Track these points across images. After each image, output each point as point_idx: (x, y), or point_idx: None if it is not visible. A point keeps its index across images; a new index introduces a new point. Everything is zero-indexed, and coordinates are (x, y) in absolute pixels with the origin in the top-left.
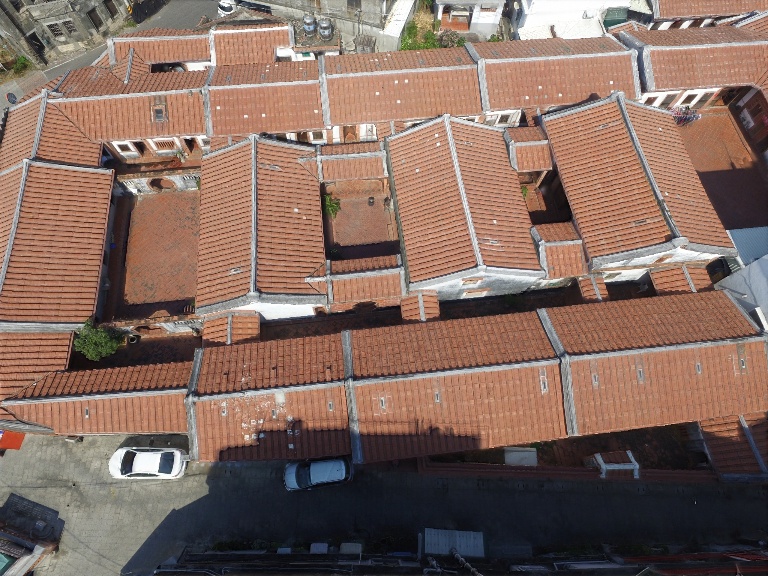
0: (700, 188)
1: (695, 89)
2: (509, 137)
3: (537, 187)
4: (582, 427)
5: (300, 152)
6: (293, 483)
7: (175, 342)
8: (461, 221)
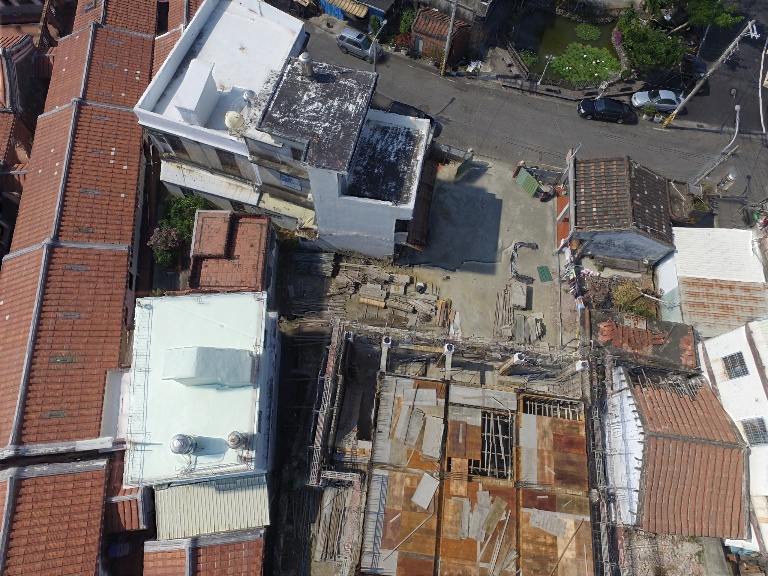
0: None
1: None
2: None
3: None
4: None
5: (2, 95)
6: None
7: None
8: None
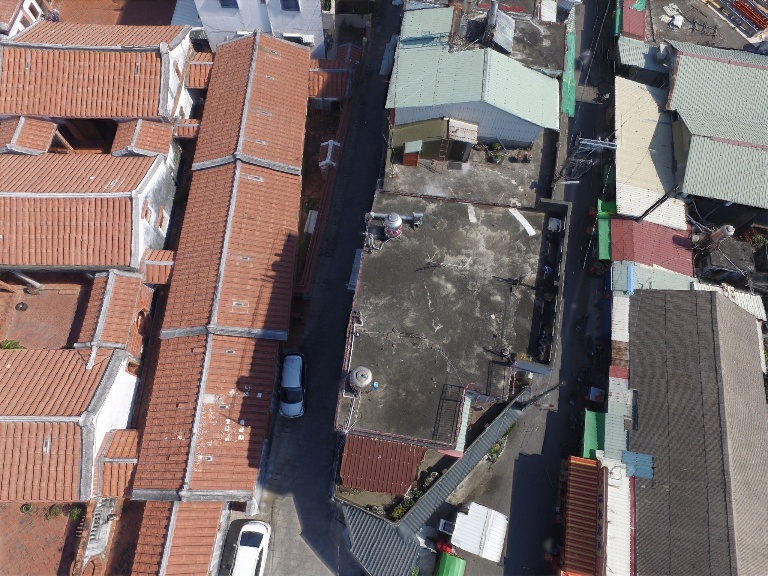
0: (124, 27)
1: (24, 1)
2: (1, 148)
3: (73, 150)
4: (295, 163)
5: None
6: (297, 407)
7: (119, 546)
8: (78, 204)
